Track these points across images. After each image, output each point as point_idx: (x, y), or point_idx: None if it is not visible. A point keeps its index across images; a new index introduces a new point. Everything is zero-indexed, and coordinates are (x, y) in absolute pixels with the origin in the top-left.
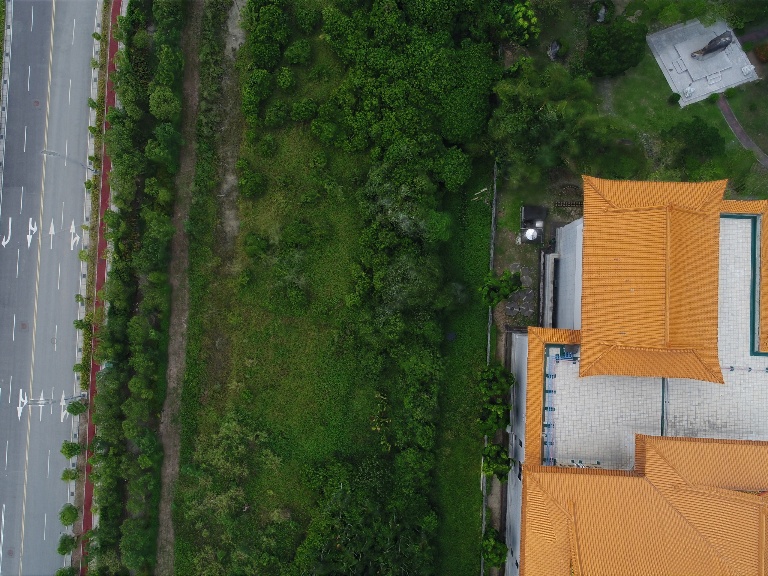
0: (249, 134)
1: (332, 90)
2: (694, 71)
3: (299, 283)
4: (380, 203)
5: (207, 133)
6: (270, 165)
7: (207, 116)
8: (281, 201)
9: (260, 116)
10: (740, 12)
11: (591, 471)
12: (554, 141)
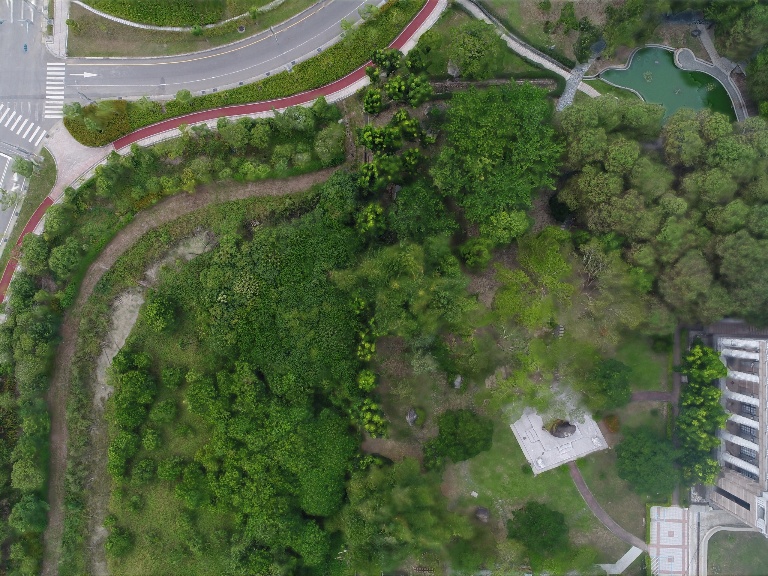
0: (115, 495)
1: (196, 453)
2: (546, 442)
3: None
4: None
5: (74, 490)
6: (138, 521)
7: (75, 472)
8: (148, 558)
9: (128, 470)
10: (582, 406)
11: None
12: (397, 554)
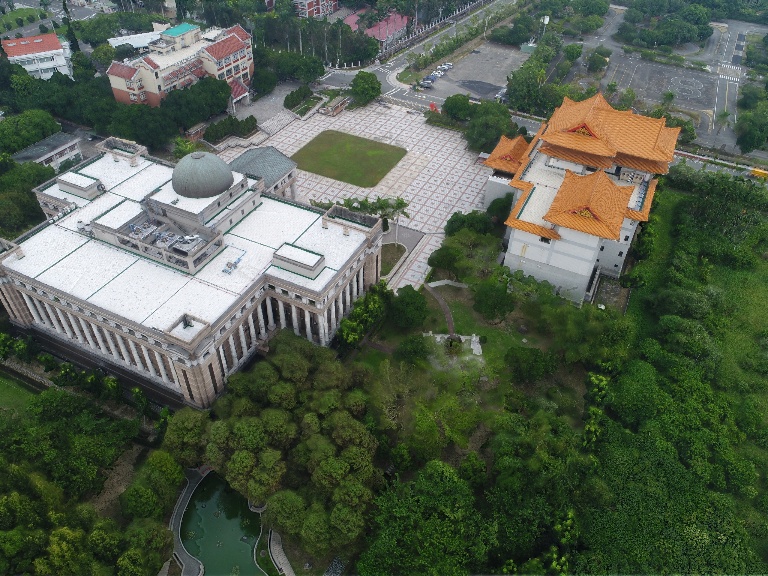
0: None
1: None
2: None
3: (766, 340)
4: (710, 345)
5: None
6: None
7: None
8: None
9: None
10: None
11: (633, 166)
12: None
